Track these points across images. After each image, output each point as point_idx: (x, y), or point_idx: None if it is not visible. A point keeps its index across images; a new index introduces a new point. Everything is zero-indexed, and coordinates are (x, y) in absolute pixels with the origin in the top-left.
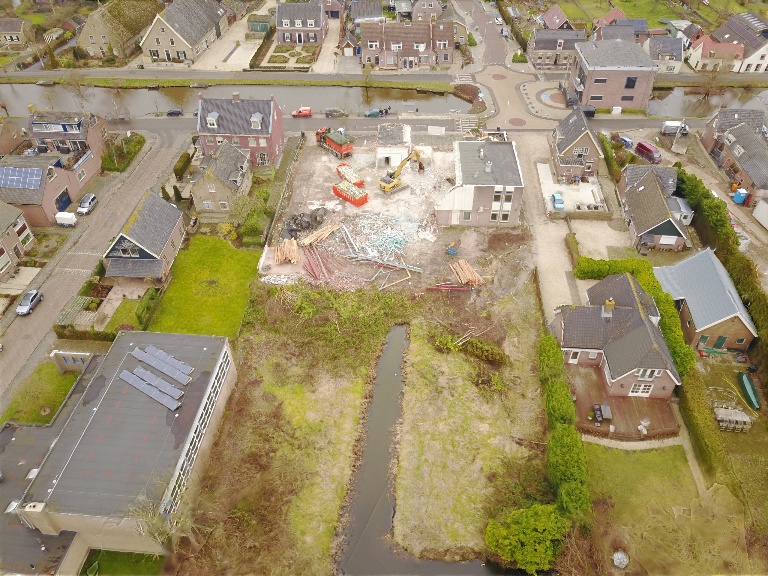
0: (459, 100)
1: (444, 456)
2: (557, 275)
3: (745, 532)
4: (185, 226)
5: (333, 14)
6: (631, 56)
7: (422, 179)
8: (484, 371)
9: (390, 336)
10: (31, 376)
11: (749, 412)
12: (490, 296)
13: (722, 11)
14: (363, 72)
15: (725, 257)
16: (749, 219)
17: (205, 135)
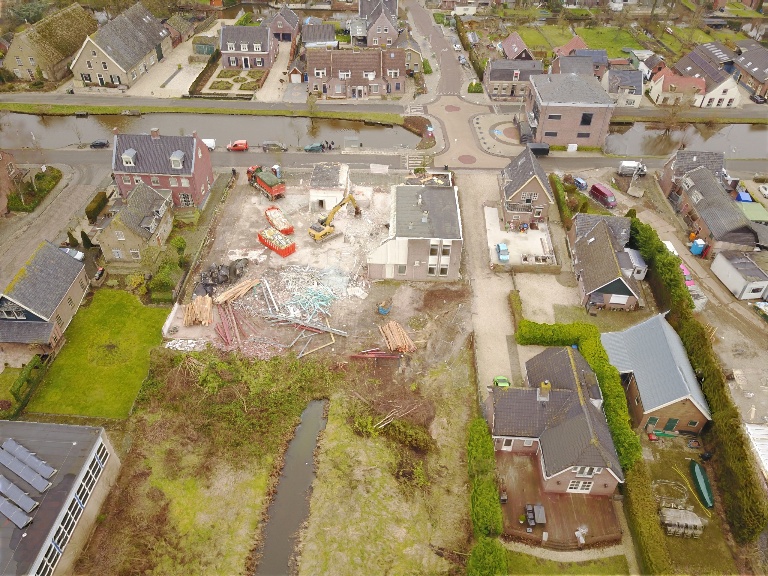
0: (409, 133)
1: (351, 572)
2: (497, 340)
3: None
4: (89, 279)
5: (285, 37)
6: (586, 91)
7: (358, 225)
8: (407, 459)
9: (305, 414)
10: None
11: (701, 511)
12: (421, 365)
13: (686, 41)
14: (307, 102)
15: (679, 321)
16: (707, 273)
17: (121, 174)
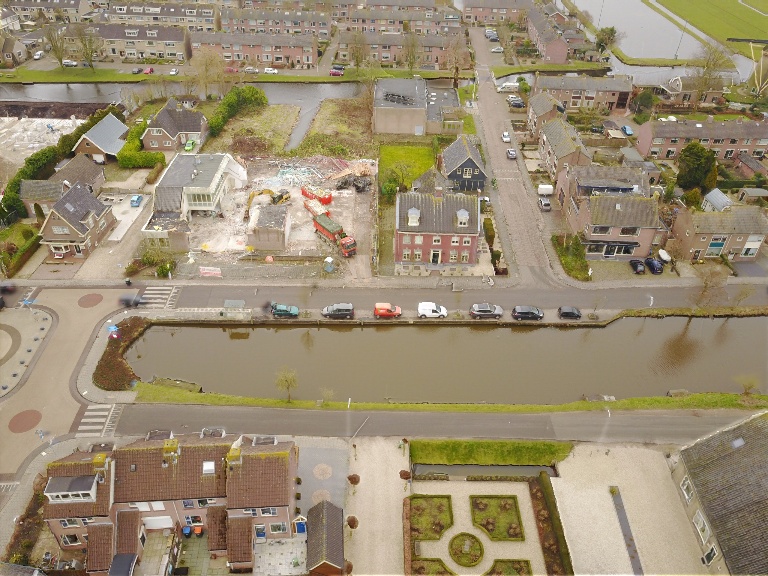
0: None
1: None
2: None
3: (177, 95)
4: None
5: None
6: None
7: None
8: None
9: None
10: None
11: None
12: None
13: None
14: None
15: None
16: None
17: None
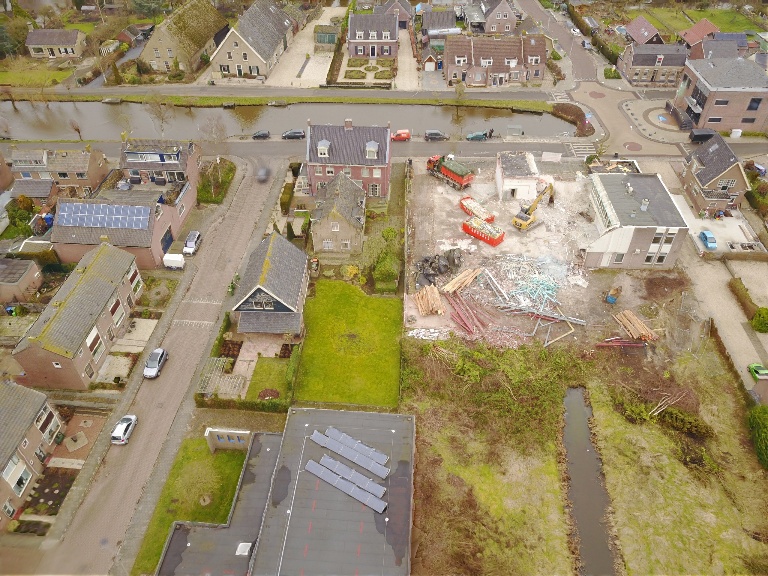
0: (559, 120)
1: (677, 556)
2: (733, 327)
3: None
4: (308, 269)
5: (400, 24)
6: (755, 76)
7: (553, 213)
8: (688, 446)
9: (567, 402)
10: (177, 455)
11: None
12: (666, 353)
13: None
14: (456, 90)
15: None
16: None
17: (315, 165)
